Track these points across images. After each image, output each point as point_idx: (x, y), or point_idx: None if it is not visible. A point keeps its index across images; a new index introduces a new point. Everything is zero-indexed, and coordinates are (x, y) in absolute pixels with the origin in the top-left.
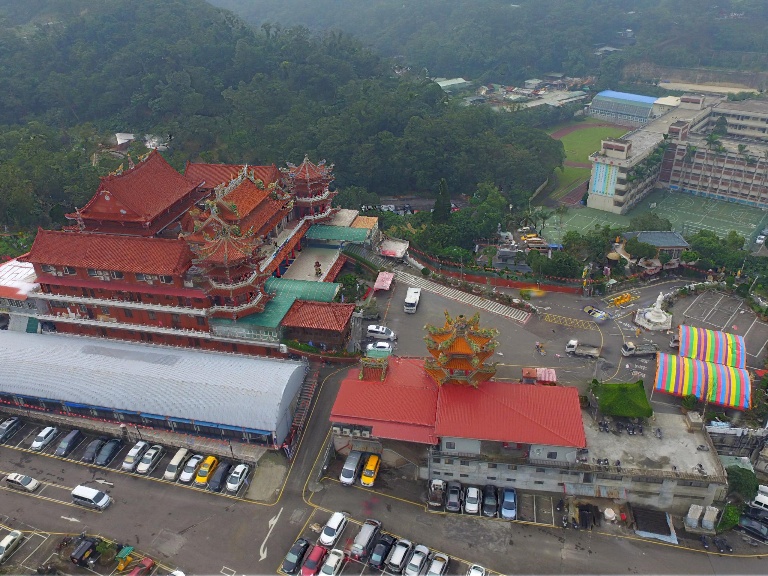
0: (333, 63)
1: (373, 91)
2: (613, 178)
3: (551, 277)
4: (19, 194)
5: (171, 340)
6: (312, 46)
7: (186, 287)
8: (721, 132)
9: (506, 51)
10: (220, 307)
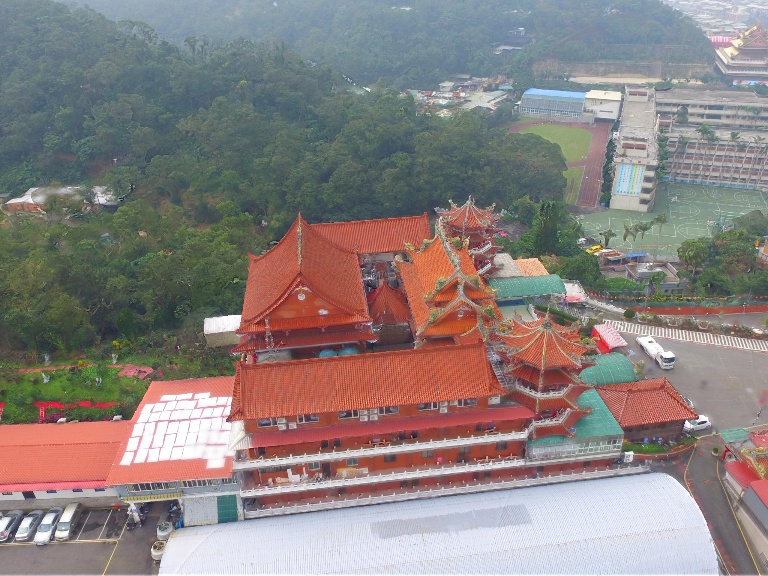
0: (297, 79)
1: (349, 108)
2: (639, 177)
3: (762, 297)
4: (61, 305)
5: (448, 478)
6: (259, 61)
7: (492, 406)
8: (683, 121)
9: (415, 55)
10: (539, 422)
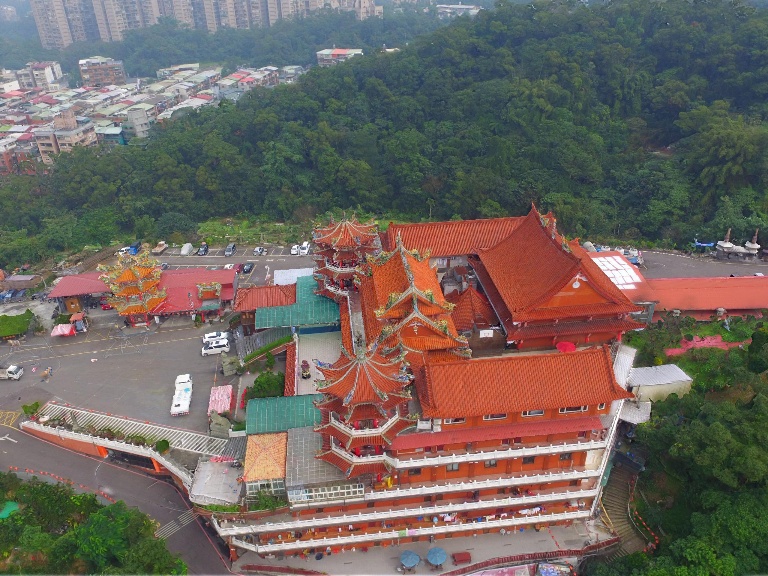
0: None
1: None
2: None
3: None
4: None
5: None
6: None
7: None
8: None
9: None
10: None
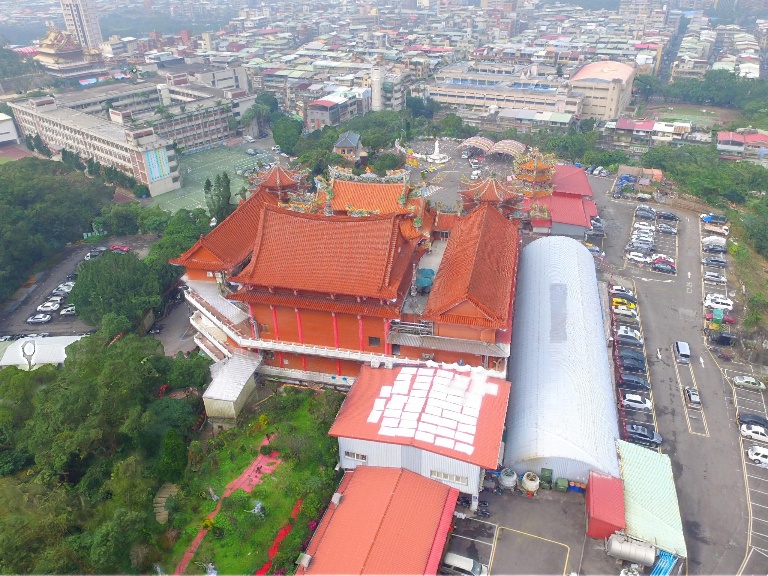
0: None
1: None
2: (164, 159)
3: None
4: None
5: None
6: None
7: None
8: None
9: None
10: None
